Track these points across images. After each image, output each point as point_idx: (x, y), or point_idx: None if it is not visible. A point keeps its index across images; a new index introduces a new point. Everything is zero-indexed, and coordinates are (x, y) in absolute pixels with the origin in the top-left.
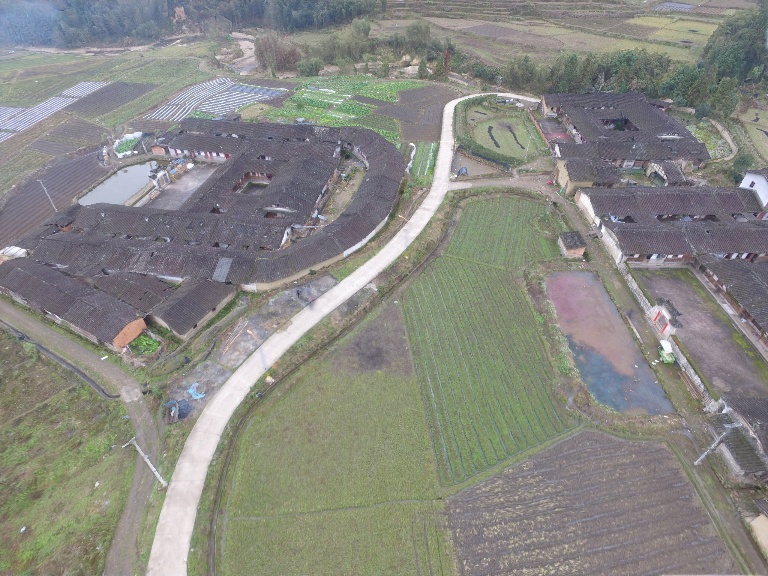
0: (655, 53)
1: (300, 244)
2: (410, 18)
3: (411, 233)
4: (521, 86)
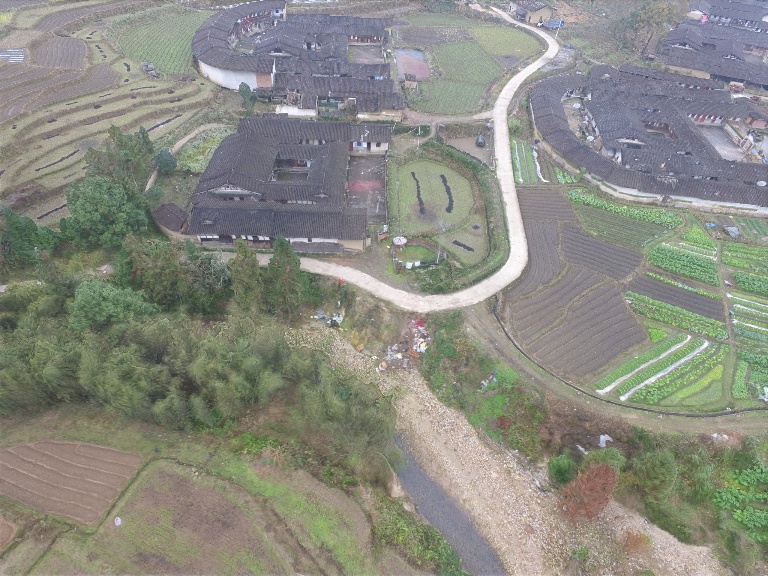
0: None
1: (573, 81)
2: None
3: (510, 86)
4: None
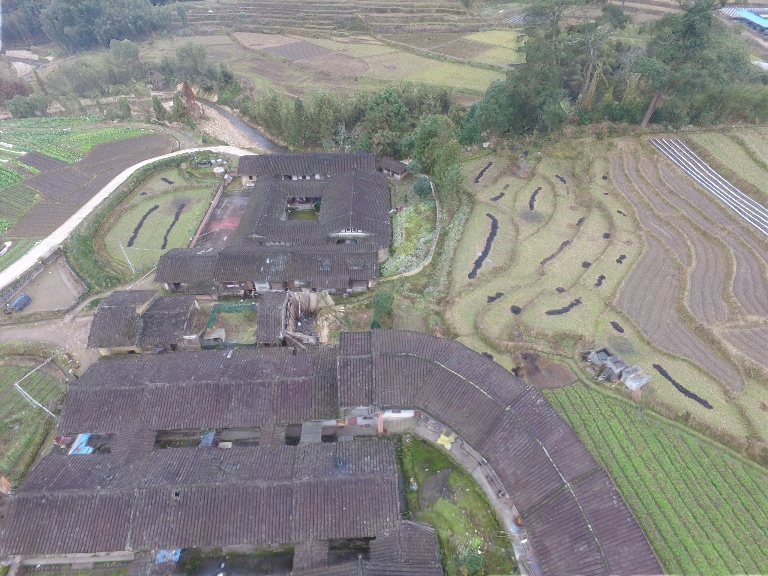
0: (438, 88)
1: None
2: (219, 33)
3: None
4: (276, 131)
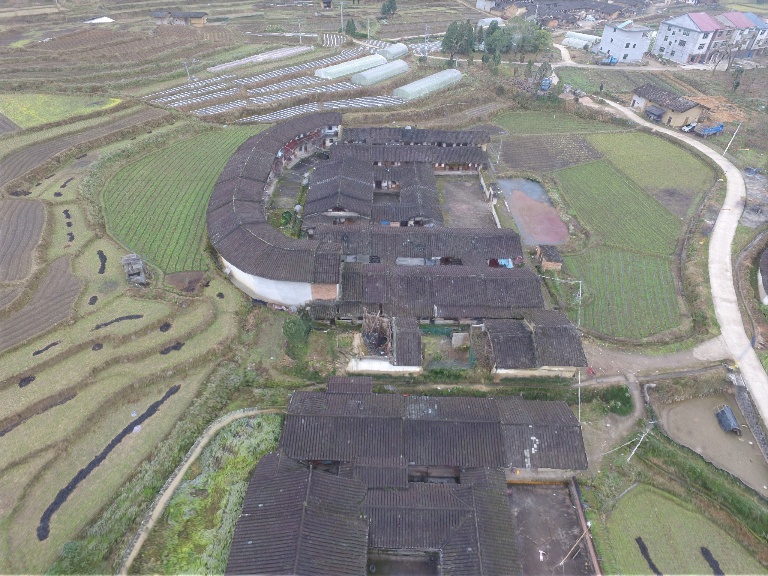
0: None
1: None
2: None
3: (718, 267)
4: None
